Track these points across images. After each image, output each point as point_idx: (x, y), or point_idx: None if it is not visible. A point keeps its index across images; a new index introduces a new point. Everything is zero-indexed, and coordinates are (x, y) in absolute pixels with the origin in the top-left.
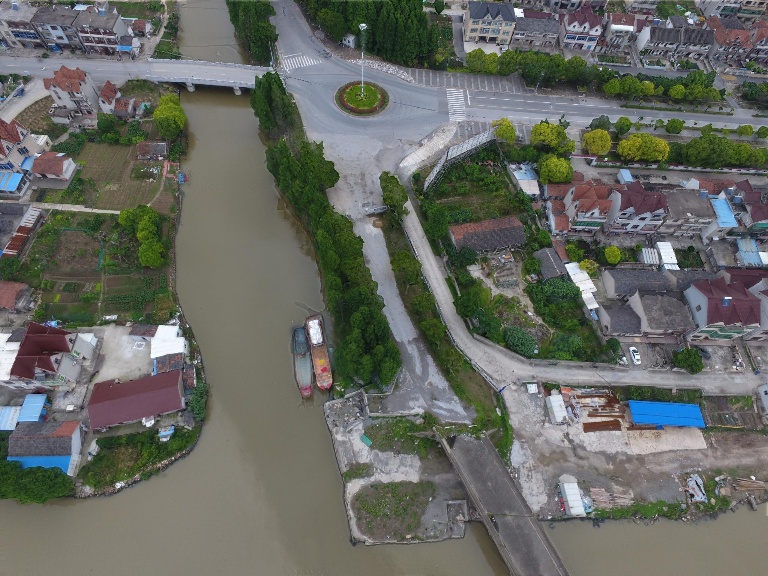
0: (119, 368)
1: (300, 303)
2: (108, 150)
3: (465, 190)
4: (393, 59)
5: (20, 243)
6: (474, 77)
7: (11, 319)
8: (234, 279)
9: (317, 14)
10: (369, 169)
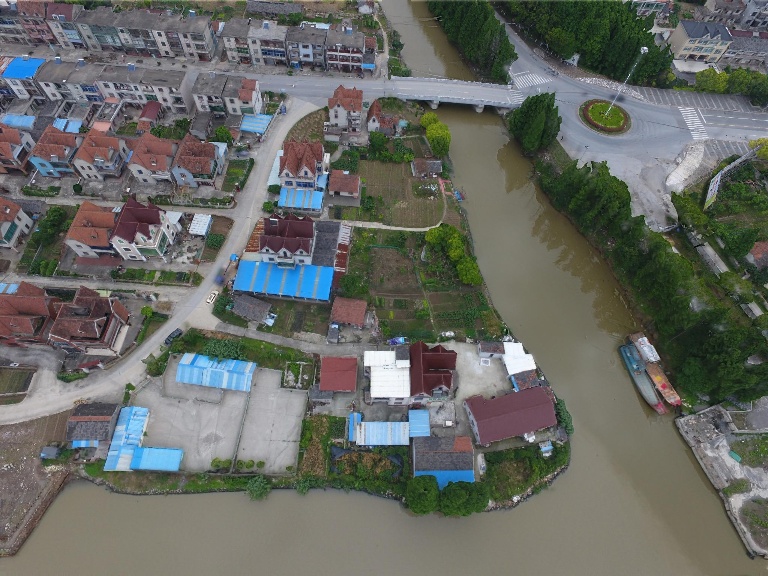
0: (475, 384)
1: (614, 320)
2: (382, 168)
3: (739, 209)
4: (623, 78)
5: (344, 260)
6: (700, 95)
7: (357, 335)
8: (528, 295)
9: (547, 33)
10: (639, 188)
